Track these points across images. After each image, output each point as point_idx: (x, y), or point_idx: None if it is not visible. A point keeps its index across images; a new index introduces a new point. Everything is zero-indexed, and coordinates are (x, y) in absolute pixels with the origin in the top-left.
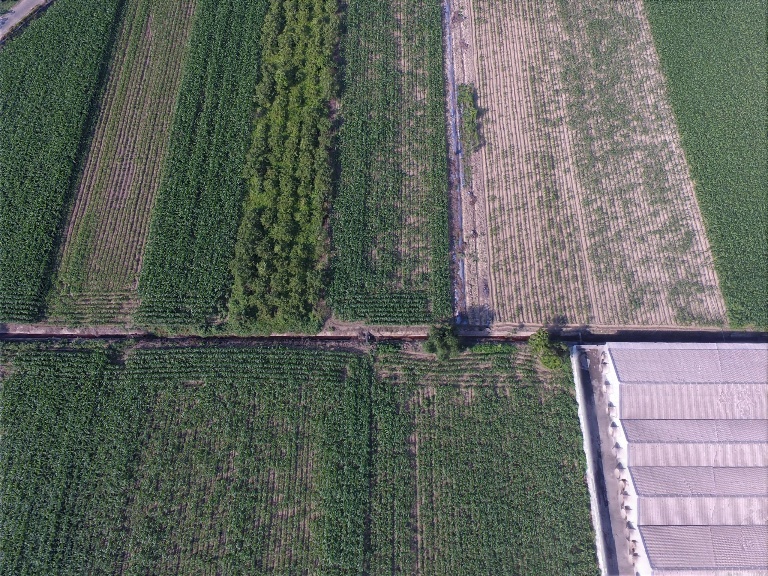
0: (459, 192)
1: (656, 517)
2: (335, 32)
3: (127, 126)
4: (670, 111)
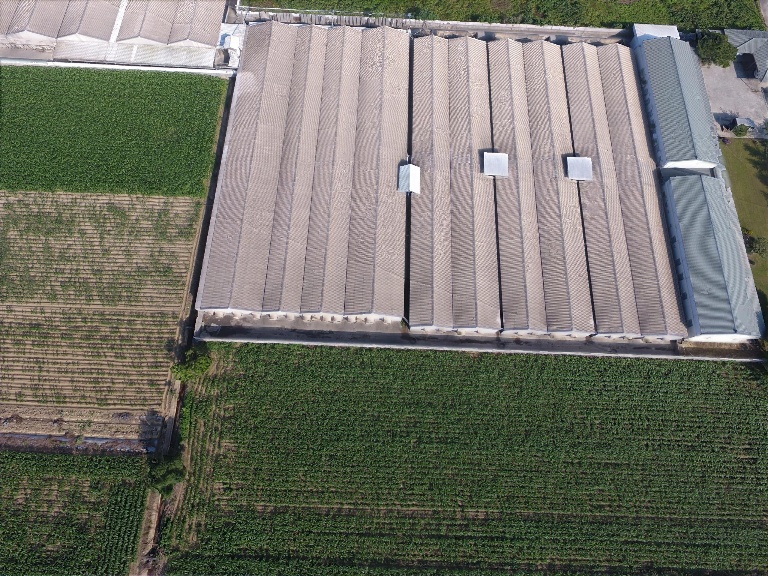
0: (1, 435)
1: (338, 300)
2: None
3: None
4: None
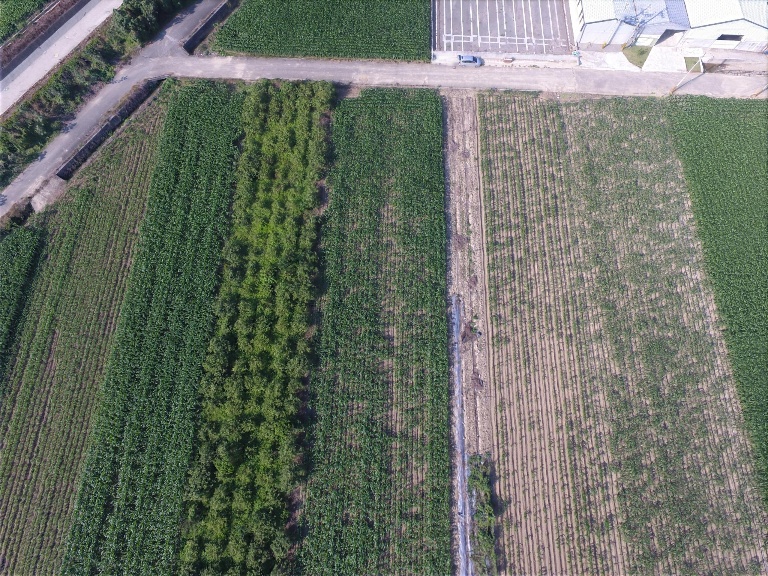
0: None
1: None
2: (303, 372)
3: (5, 536)
4: (761, 504)
